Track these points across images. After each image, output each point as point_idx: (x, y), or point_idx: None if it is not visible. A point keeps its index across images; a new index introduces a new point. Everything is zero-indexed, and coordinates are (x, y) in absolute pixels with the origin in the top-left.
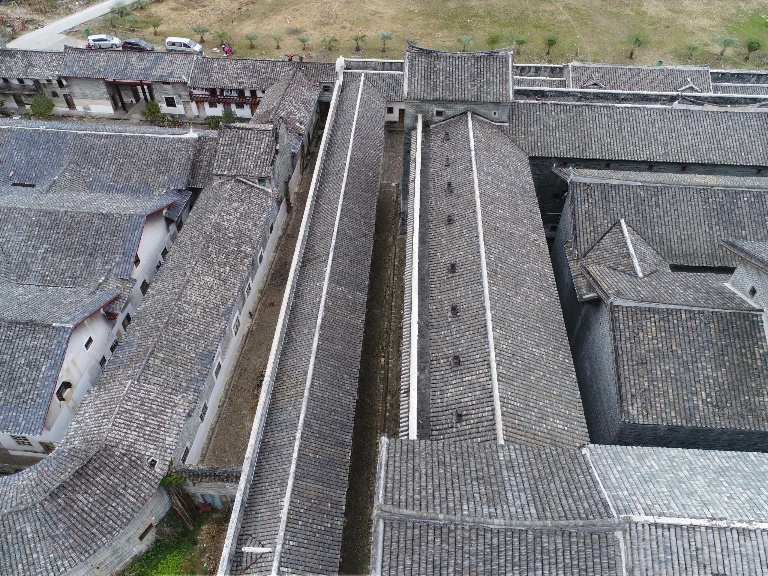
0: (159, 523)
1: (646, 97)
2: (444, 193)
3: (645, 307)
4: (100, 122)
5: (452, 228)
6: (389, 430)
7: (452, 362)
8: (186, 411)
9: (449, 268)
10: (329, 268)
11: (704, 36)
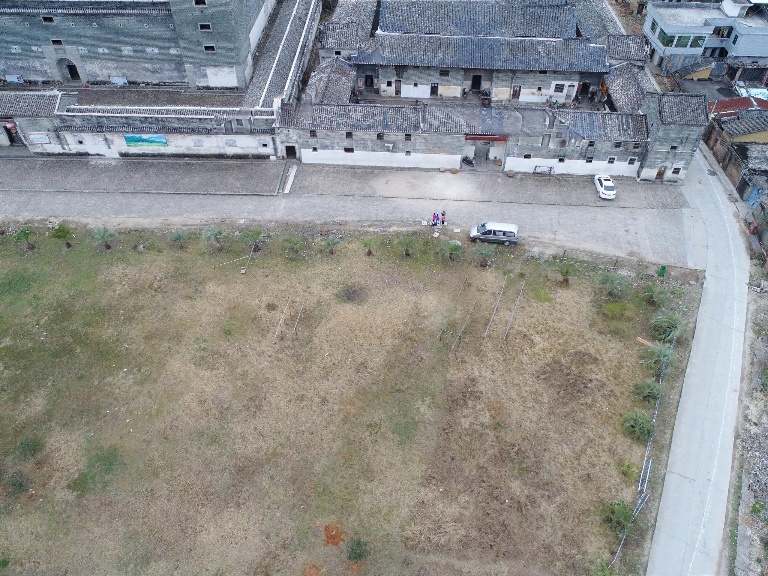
0: None
1: None
2: None
3: None
4: (508, 140)
5: None
6: None
7: None
8: None
9: None
10: (294, 11)
11: None
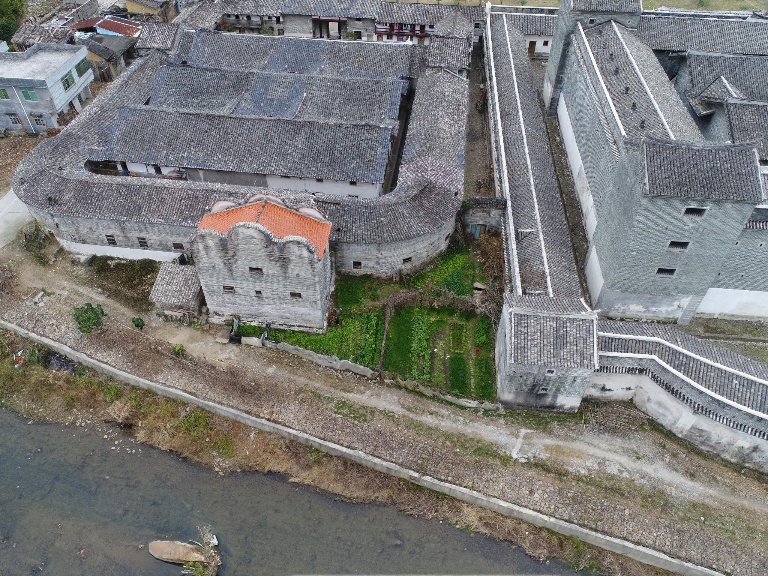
0: (452, 236)
1: (726, 18)
2: (607, 61)
3: (746, 104)
4: None
5: (619, 76)
6: (569, 210)
7: (639, 127)
8: (463, 176)
9: (623, 92)
10: None
11: (751, 2)
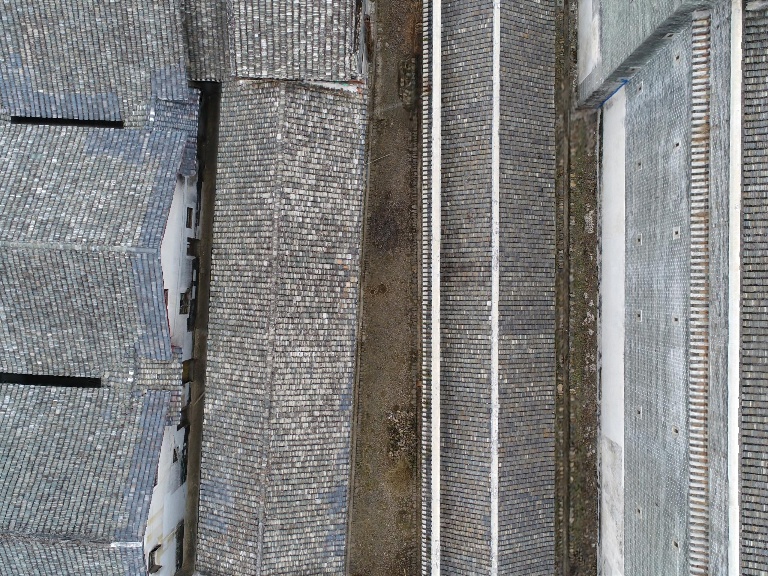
0: None
1: None
2: None
3: None
4: None
5: None
6: (575, 503)
7: None
8: None
9: None
10: (497, 309)
11: None
